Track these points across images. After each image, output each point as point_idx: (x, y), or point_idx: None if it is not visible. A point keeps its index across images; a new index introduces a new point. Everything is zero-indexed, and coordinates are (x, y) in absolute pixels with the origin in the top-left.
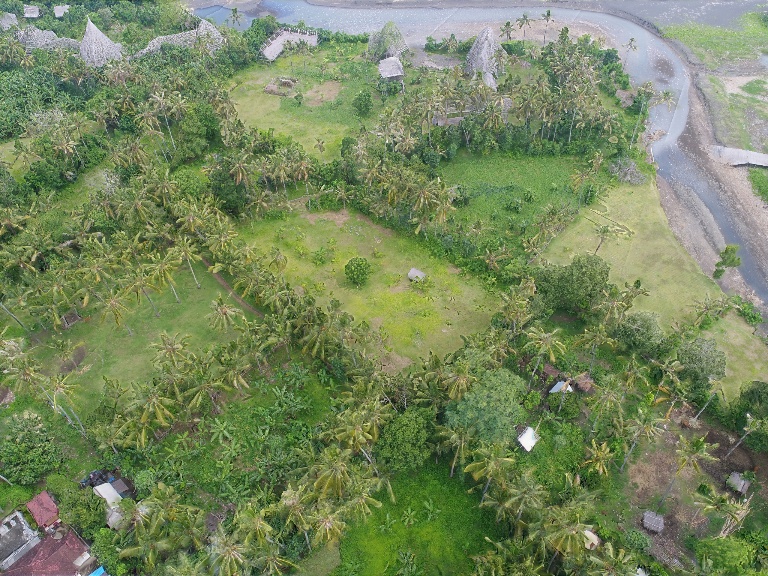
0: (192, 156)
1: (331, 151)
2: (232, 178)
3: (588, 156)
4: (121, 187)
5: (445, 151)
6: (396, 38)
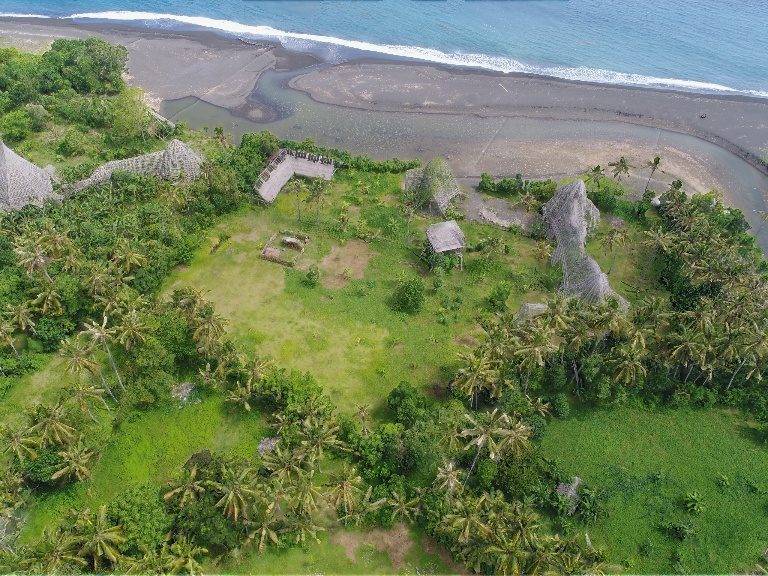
0: (151, 401)
1: (368, 384)
2: (220, 510)
3: (767, 425)
4: (25, 484)
5: (549, 405)
6: (445, 180)
